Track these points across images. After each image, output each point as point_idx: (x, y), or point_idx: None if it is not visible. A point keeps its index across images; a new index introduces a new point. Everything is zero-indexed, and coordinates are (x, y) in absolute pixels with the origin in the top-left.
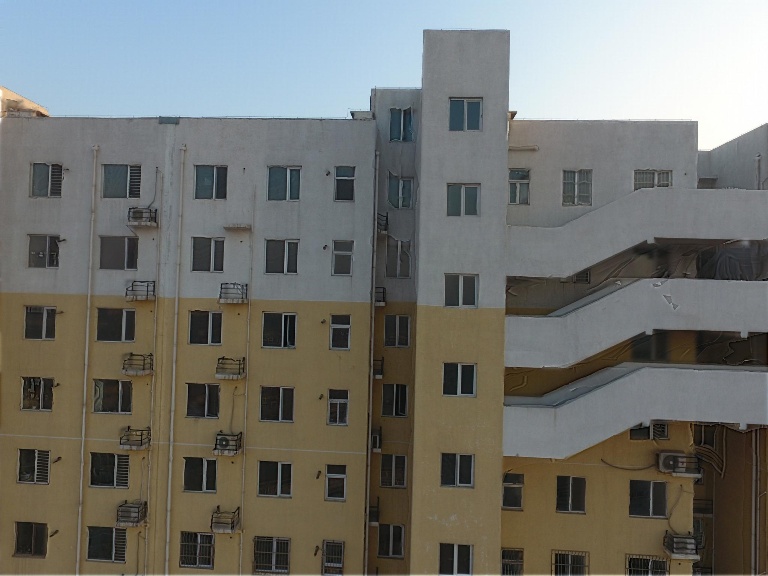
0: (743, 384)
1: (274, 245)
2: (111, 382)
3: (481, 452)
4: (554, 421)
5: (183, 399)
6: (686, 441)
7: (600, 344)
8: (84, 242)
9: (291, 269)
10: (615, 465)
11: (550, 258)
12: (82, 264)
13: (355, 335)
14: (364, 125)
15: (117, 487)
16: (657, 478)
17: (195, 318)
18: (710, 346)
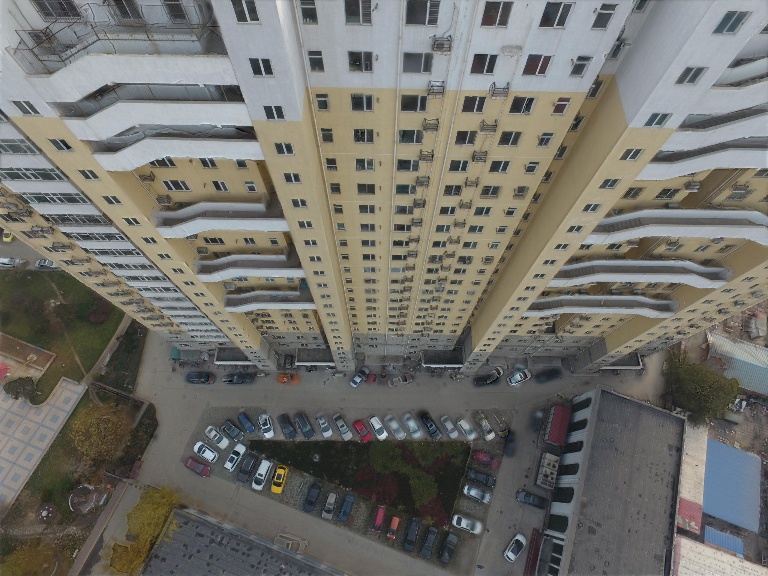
0: None
1: (534, 58)
2: (410, 131)
3: (625, 179)
4: (668, 168)
5: (454, 138)
6: None
7: (717, 142)
8: (393, 58)
9: (541, 72)
10: None
11: (721, 107)
12: (391, 71)
13: (571, 109)
14: None
15: (412, 171)
16: None
17: (468, 100)
18: None
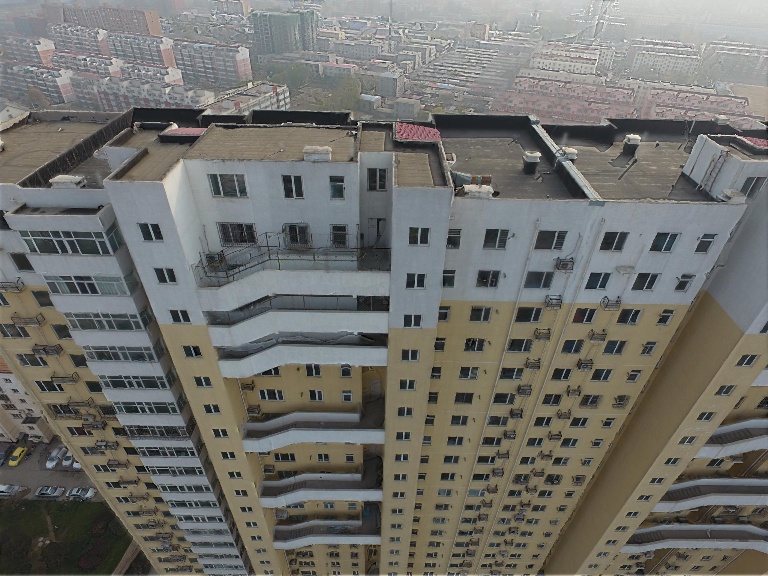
0: None
1: (643, 276)
2: (521, 340)
3: (741, 385)
4: None
5: None
6: None
7: None
8: (519, 275)
9: (648, 287)
10: None
11: None
12: (514, 286)
13: (674, 320)
14: (737, 208)
15: (515, 380)
16: None
17: (579, 311)
18: None
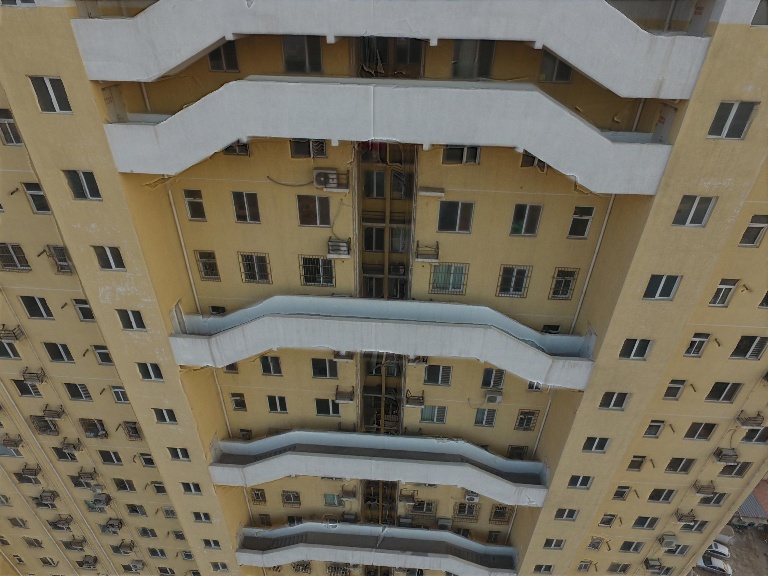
0: (333, 98)
1: None
2: None
3: (97, 169)
4: (156, 138)
5: None
6: (343, 159)
7: (179, 52)
8: None
9: None
10: (279, 182)
11: None
12: None
13: None
14: None
15: None
16: (320, 193)
17: None
18: (322, 55)
